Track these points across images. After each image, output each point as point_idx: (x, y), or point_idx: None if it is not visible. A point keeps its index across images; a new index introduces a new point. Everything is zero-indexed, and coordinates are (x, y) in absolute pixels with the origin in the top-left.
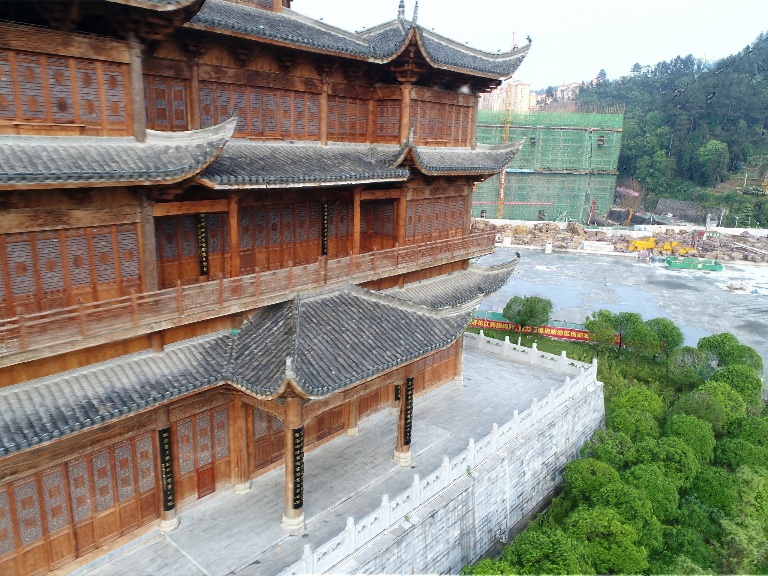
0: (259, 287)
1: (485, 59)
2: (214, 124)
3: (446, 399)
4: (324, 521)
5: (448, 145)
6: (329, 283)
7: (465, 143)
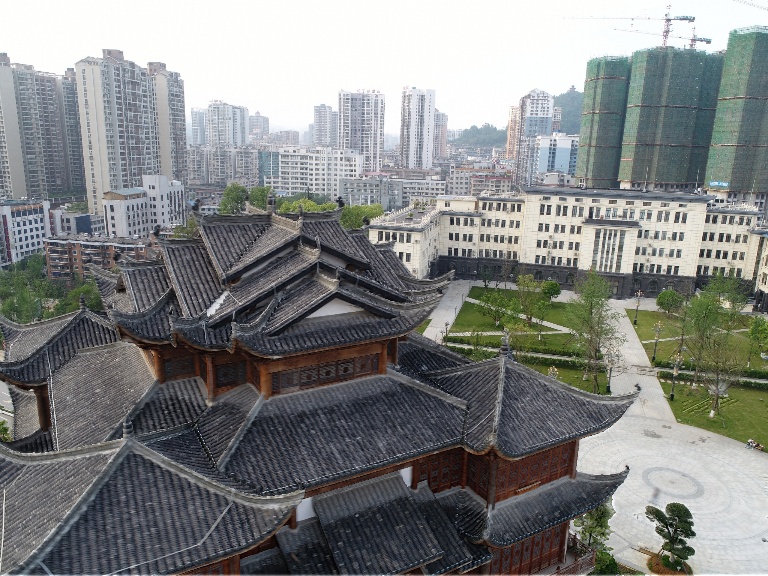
0: None
1: None
2: None
3: None
4: None
5: None
6: None
7: None
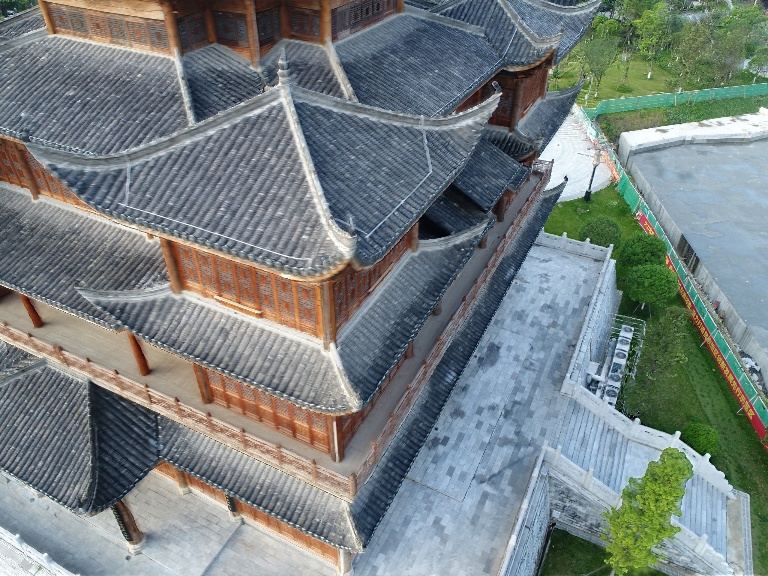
0: (12, 335)
1: (320, 218)
2: (47, 186)
3: (291, 567)
4: (48, 507)
5: (271, 318)
6: (71, 368)
7: (314, 330)
